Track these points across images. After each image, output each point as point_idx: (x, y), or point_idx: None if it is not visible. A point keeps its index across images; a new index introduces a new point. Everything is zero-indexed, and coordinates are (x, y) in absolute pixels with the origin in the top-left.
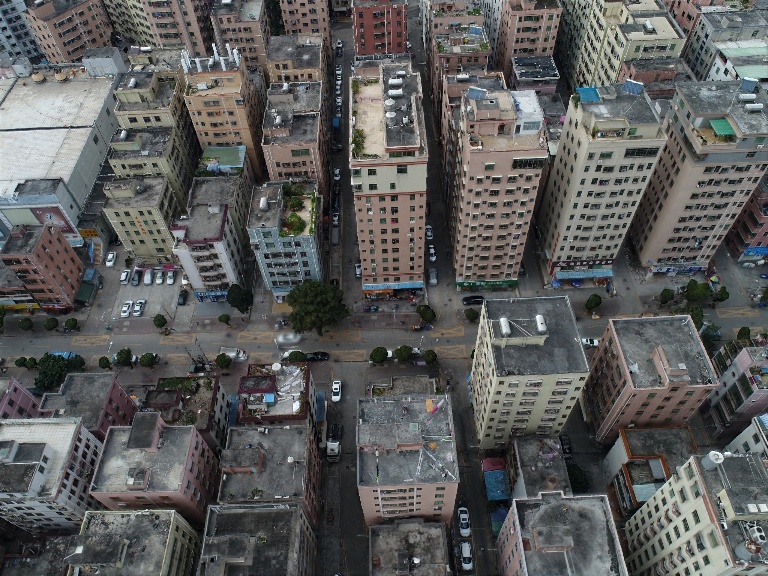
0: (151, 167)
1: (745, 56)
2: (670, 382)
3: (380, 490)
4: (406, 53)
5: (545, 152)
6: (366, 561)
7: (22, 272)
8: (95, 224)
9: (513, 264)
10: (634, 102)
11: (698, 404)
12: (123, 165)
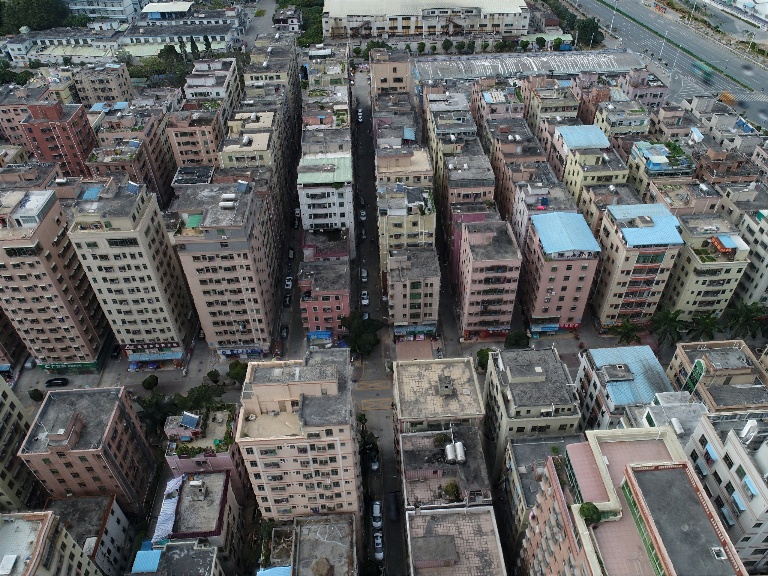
0: None
1: (312, 165)
2: (47, 447)
3: None
4: (54, 162)
5: (30, 242)
6: None
7: None
8: None
9: (79, 347)
10: (126, 200)
11: (109, 471)
12: None
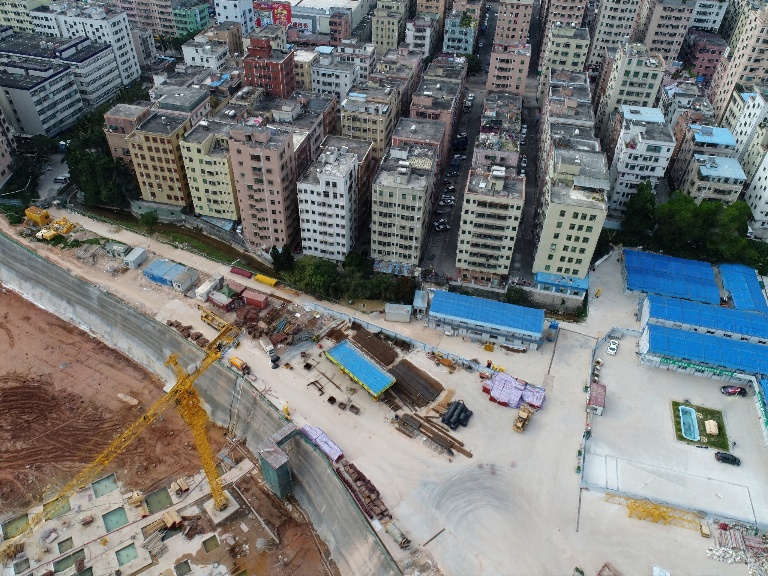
0: (395, 9)
1: None
2: None
3: (499, 58)
4: None
5: None
6: (478, 134)
7: (333, 32)
8: (358, 36)
9: None
10: None
11: None
12: (383, 6)
